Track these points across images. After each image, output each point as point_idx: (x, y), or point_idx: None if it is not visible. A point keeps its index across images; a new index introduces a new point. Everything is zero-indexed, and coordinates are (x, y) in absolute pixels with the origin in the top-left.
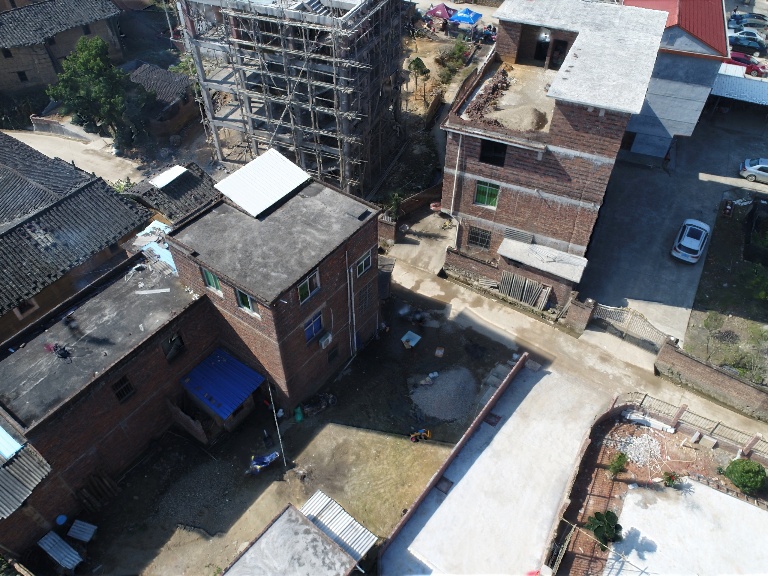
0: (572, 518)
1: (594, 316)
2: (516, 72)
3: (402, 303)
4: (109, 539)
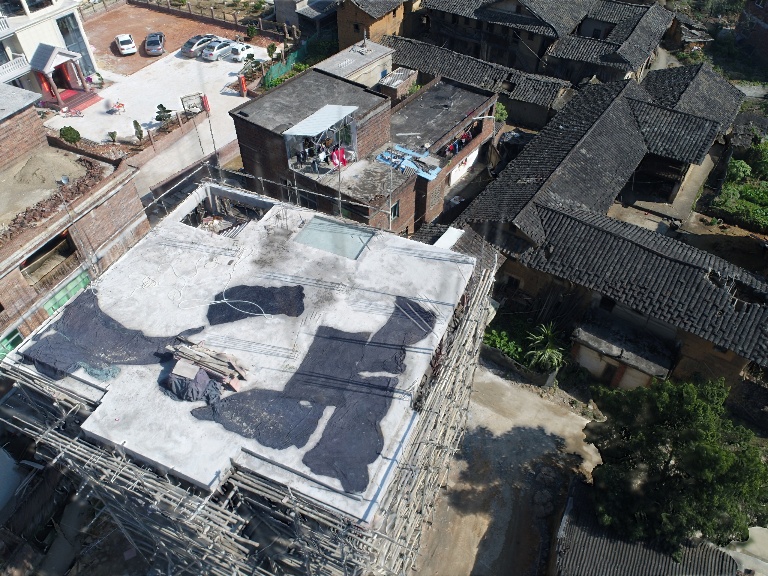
0: None
1: None
2: None
3: None
4: None
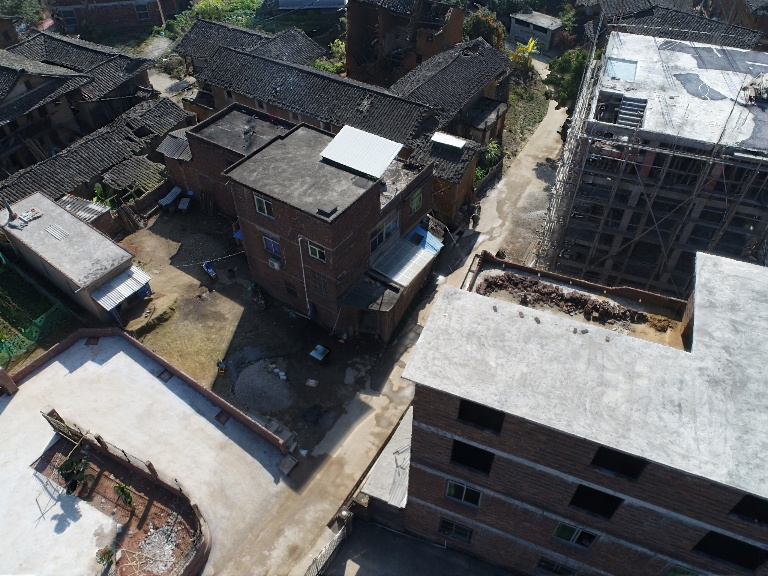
0: (108, 467)
1: (344, 536)
2: (652, 334)
3: (378, 352)
4: (182, 218)
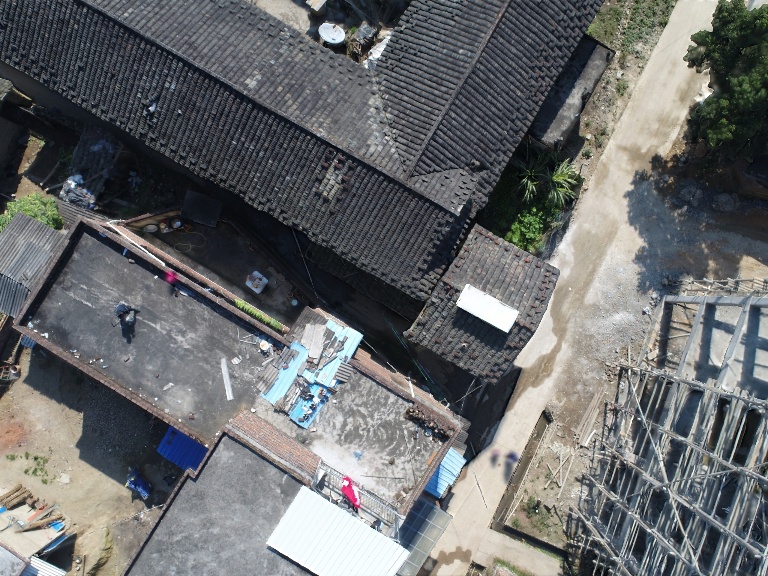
0: None
1: None
2: None
3: None
4: None
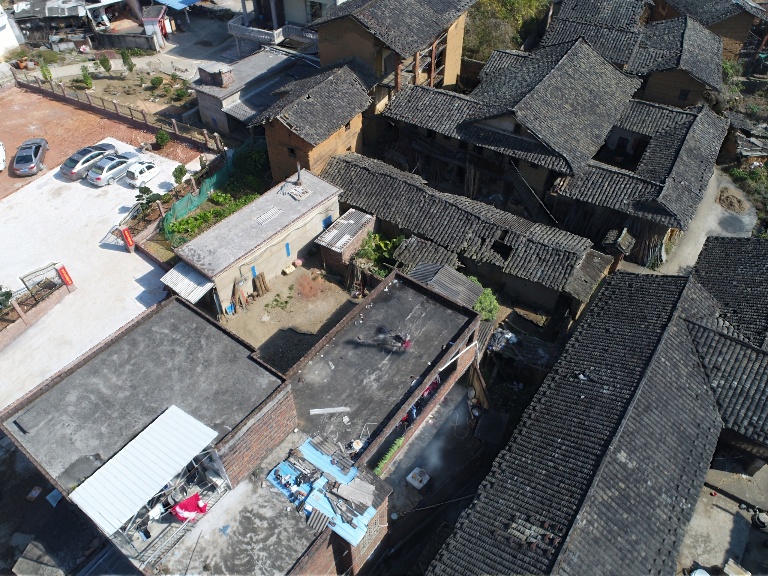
0: None
1: None
2: None
3: None
4: None
